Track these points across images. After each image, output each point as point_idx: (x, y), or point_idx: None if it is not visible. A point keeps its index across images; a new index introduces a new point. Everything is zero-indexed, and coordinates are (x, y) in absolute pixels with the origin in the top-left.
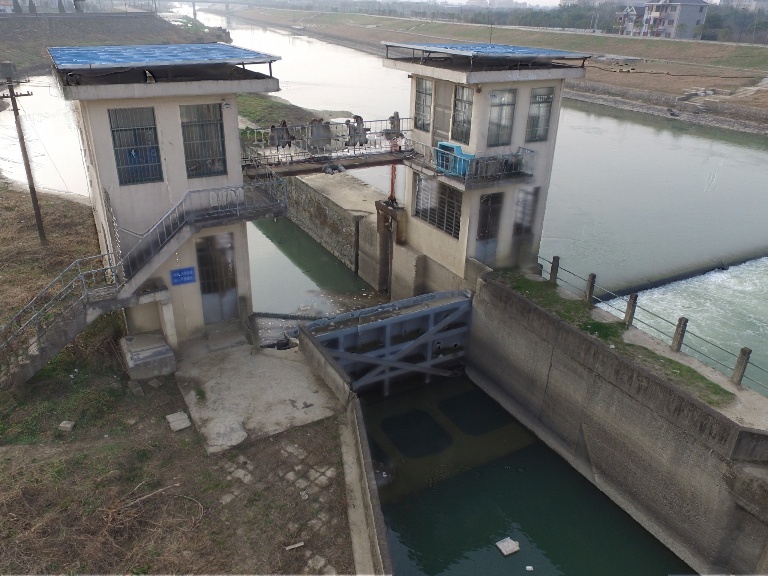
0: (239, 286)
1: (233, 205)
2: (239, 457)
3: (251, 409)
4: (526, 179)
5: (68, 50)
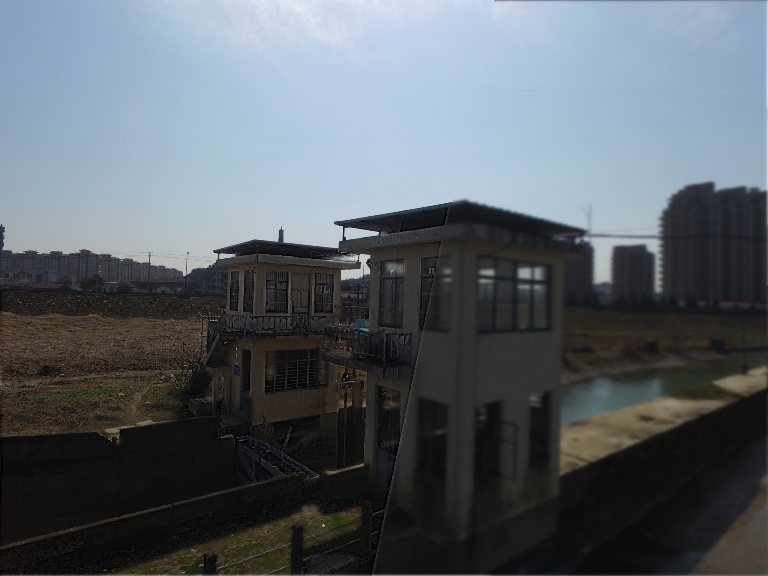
0: None
1: (252, 332)
2: None
3: None
4: (375, 368)
5: None
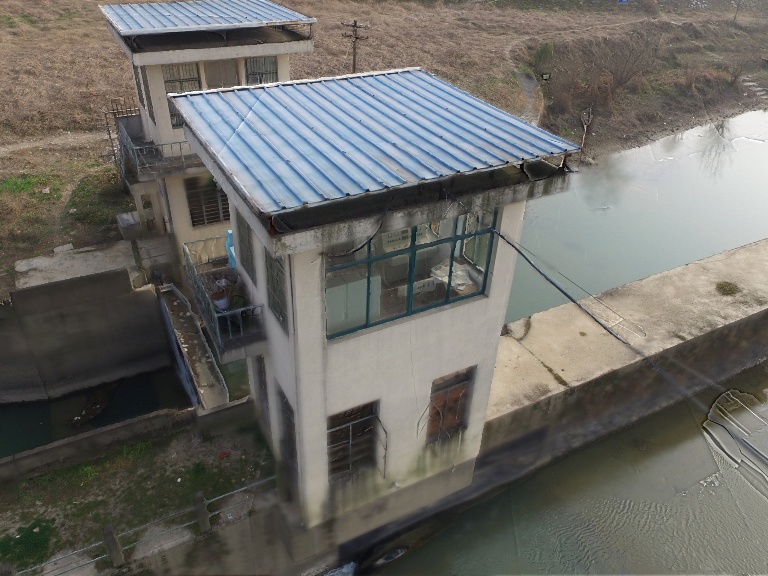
0: None
1: None
2: (6, 273)
3: (51, 271)
4: None
5: (230, 1)
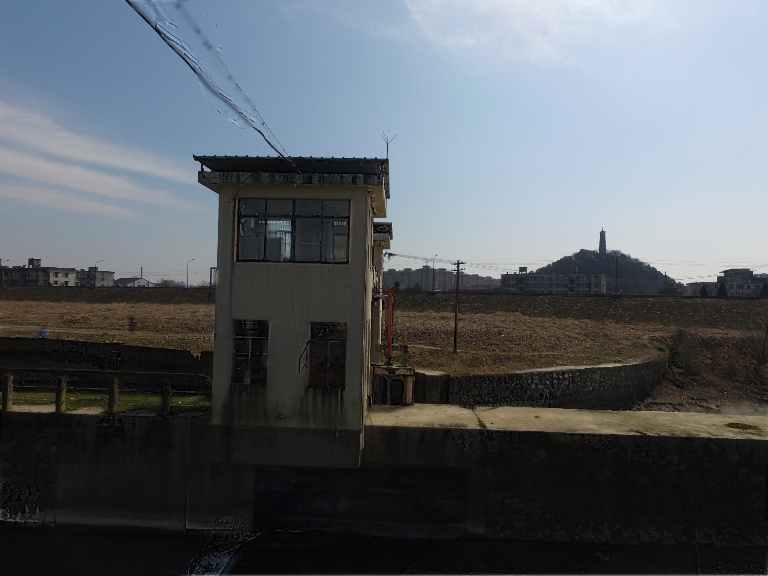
0: None
1: None
2: None
3: None
4: None
5: None
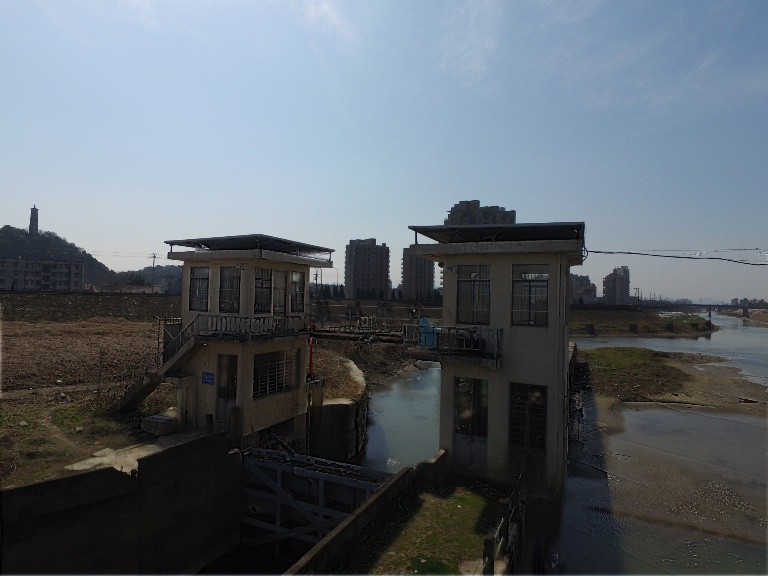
0: (237, 398)
1: (239, 335)
2: None
3: (122, 462)
4: (484, 361)
5: None
